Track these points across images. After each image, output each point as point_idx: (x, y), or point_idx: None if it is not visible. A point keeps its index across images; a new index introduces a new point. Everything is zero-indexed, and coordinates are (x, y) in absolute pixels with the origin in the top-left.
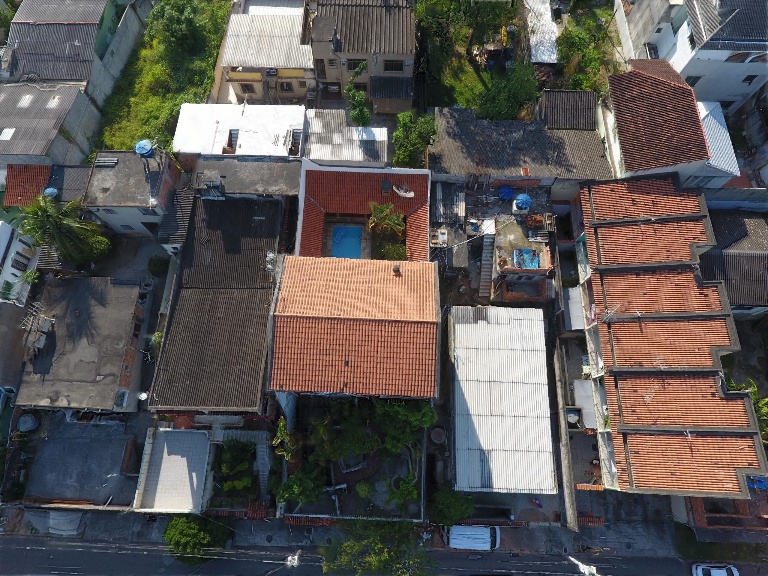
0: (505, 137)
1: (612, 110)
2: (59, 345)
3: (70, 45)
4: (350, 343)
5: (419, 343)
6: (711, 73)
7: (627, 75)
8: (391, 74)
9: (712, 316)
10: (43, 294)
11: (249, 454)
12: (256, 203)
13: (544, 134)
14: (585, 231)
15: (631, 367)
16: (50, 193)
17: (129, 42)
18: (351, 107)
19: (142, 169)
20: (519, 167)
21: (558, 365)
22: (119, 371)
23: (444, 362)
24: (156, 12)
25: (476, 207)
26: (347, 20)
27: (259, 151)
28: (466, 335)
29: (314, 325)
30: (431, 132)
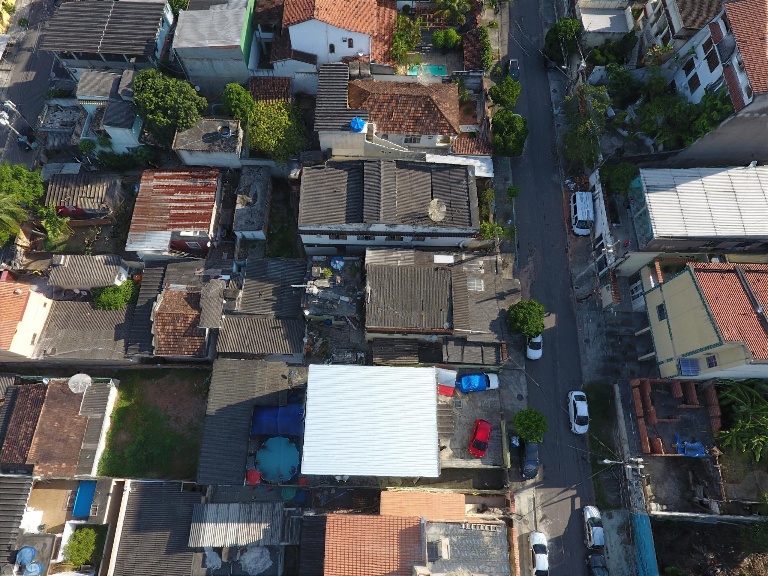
0: None
1: None
2: None
3: None
4: None
5: None
6: None
7: None
8: None
9: None
10: None
11: (625, 55)
12: None
13: None
14: None
15: None
16: None
17: None
18: None
19: None
20: None
21: None
22: None
23: None
24: None
25: None
26: None
27: None
28: None
29: None
30: None
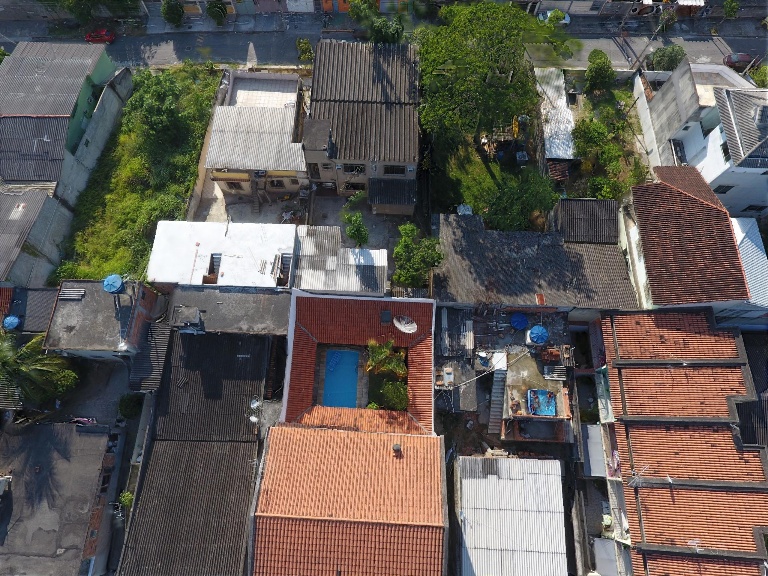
0: (517, 253)
1: (636, 226)
2: (16, 509)
3: (38, 141)
4: (343, 550)
5: (423, 551)
6: (745, 183)
7: (653, 187)
8: (392, 177)
9: (754, 489)
10: (0, 443)
11: None
12: (240, 338)
13: (561, 250)
14: (608, 371)
15: (662, 546)
16: (10, 323)
17: (107, 125)
18: (348, 205)
19: (112, 303)
20: (534, 293)
21: (577, 523)
22: (83, 543)
23: (449, 510)
24: (134, 101)
25: (485, 336)
26: (343, 119)
27: (243, 281)
28: (474, 492)
29: (301, 528)
30: (436, 257)
